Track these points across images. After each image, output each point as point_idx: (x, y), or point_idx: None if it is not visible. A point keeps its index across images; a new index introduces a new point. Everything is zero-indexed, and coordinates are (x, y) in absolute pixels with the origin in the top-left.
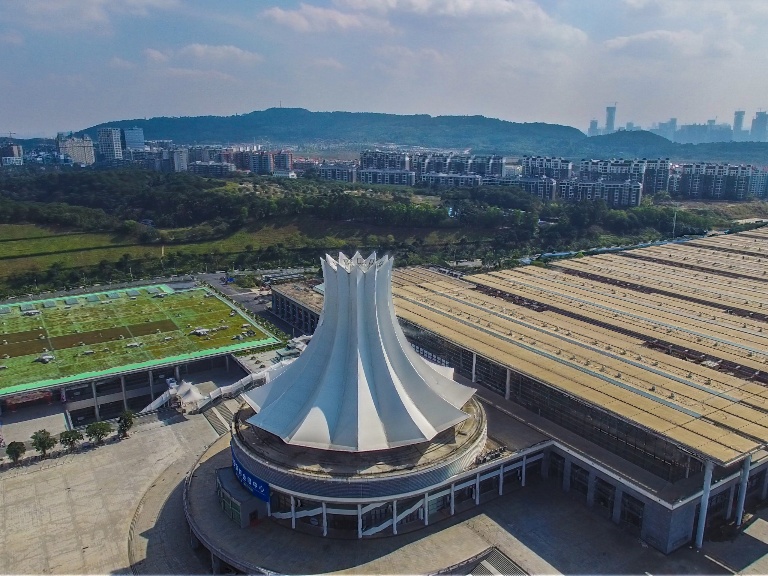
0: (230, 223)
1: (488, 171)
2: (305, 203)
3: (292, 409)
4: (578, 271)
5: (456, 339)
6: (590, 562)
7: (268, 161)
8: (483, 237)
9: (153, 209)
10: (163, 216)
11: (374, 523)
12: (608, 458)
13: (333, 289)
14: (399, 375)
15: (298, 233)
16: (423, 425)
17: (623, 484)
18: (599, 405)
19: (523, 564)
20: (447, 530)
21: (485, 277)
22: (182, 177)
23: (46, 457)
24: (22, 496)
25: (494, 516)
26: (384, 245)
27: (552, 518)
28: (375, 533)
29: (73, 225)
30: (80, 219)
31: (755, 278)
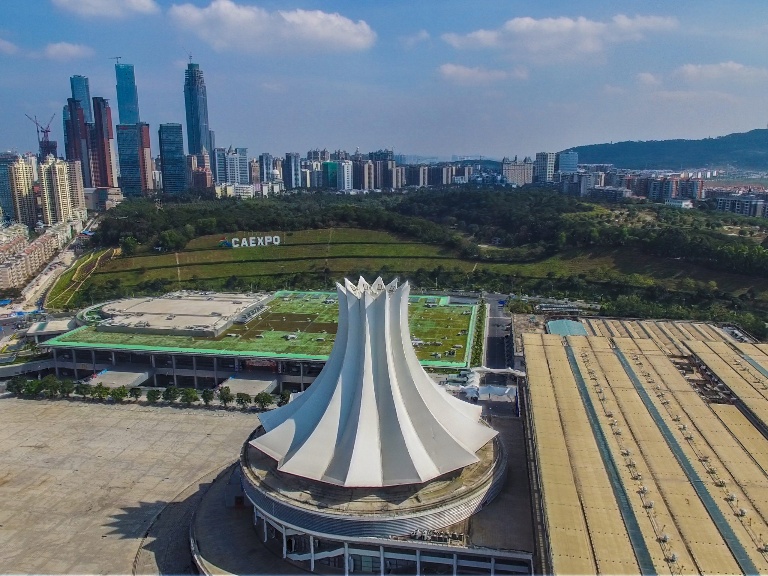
0: (546, 248)
1: None
2: (631, 234)
3: None
4: None
5: (536, 402)
6: None
7: (669, 188)
8: None
9: (508, 228)
10: (508, 235)
11: (303, 551)
12: None
13: None
14: (381, 414)
15: (610, 266)
16: (372, 472)
17: None
18: (546, 525)
19: None
20: None
21: (718, 346)
22: (558, 200)
23: (225, 408)
24: (184, 429)
25: None
26: (699, 292)
27: None
28: (297, 560)
29: (415, 235)
30: (422, 231)
31: None
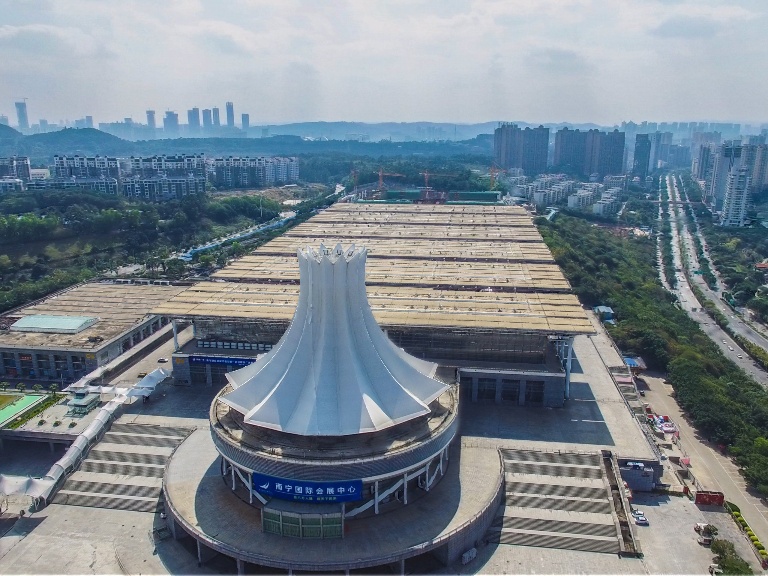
0: None
1: (13, 174)
2: None
3: (331, 408)
4: (289, 253)
5: None
6: (547, 429)
7: None
8: (113, 243)
9: None
10: None
11: None
12: (500, 365)
13: (329, 282)
14: None
15: None
16: None
17: (527, 375)
18: (499, 327)
19: (528, 447)
20: (463, 456)
21: (232, 272)
22: None
23: None
24: None
25: (470, 434)
26: (2, 269)
27: (495, 419)
28: (433, 482)
29: None
30: None
31: (400, 238)
